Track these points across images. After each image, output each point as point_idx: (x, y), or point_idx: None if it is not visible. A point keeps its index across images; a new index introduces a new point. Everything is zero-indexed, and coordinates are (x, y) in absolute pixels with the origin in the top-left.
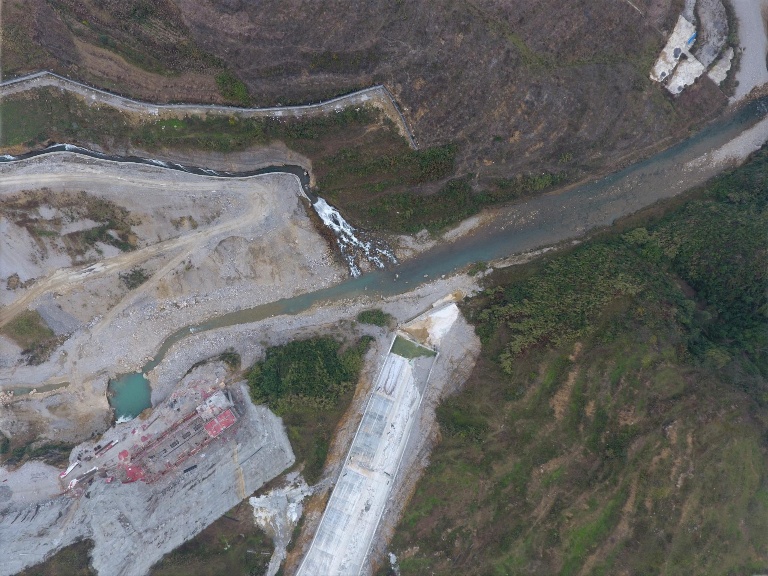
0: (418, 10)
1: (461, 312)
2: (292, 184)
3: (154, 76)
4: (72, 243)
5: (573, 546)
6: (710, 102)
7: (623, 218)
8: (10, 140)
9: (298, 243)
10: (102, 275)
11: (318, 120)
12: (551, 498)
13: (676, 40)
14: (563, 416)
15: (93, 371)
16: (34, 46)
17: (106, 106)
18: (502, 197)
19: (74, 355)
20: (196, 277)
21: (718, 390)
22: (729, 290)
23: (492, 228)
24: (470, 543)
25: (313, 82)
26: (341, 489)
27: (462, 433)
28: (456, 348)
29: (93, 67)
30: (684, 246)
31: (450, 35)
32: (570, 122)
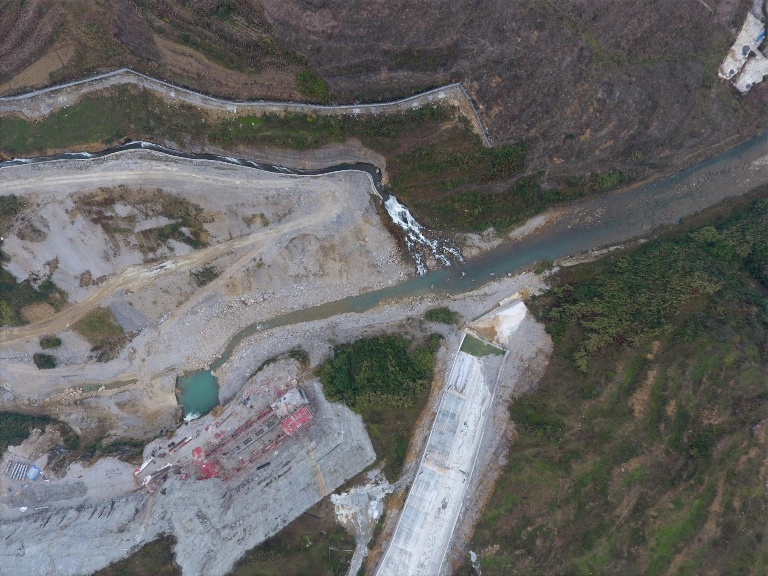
0: (496, 7)
1: (529, 310)
2: (364, 182)
3: (234, 73)
4: (145, 240)
5: (659, 545)
6: None
7: (690, 216)
8: (89, 137)
9: (368, 241)
10: (173, 272)
11: (396, 117)
12: (634, 497)
13: (745, 37)
14: (643, 415)
15: (162, 368)
16: (114, 43)
17: (185, 103)
18: (570, 195)
19: (143, 352)
20: (266, 275)
21: None
22: None
23: (558, 226)
24: (551, 541)
25: (392, 79)
26: (418, 487)
27: (539, 431)
28: (526, 346)
29: (173, 64)
30: (758, 245)
31: (526, 32)
32: (641, 120)
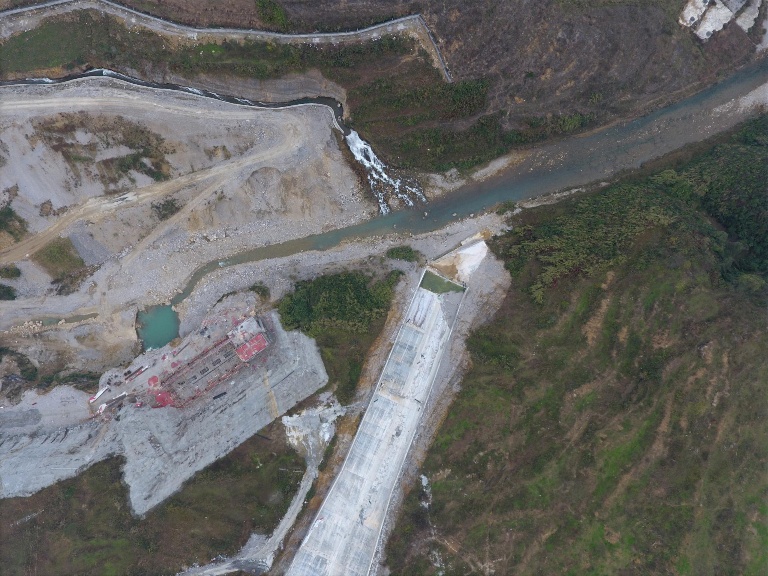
0: None
1: (490, 249)
2: (325, 116)
3: None
4: (106, 170)
5: (607, 466)
6: (738, 49)
7: (651, 161)
8: (49, 62)
9: (330, 176)
10: (134, 204)
11: (355, 47)
12: (584, 421)
13: None
14: (596, 342)
15: (122, 302)
16: None
17: (145, 29)
18: (532, 137)
19: (103, 286)
20: (227, 209)
21: (753, 313)
22: (760, 223)
23: (521, 169)
24: (502, 465)
25: (351, 9)
26: (372, 414)
27: (494, 360)
28: (485, 283)
29: None
30: (714, 183)
31: None
32: (601, 61)
